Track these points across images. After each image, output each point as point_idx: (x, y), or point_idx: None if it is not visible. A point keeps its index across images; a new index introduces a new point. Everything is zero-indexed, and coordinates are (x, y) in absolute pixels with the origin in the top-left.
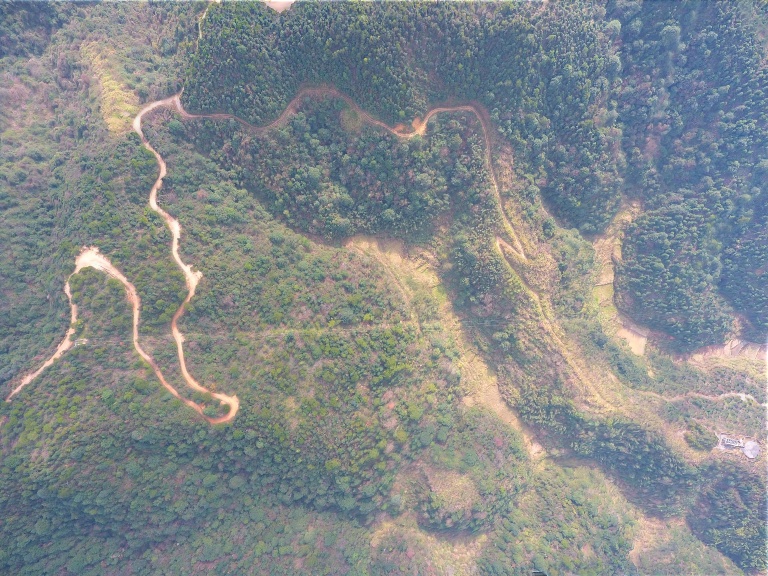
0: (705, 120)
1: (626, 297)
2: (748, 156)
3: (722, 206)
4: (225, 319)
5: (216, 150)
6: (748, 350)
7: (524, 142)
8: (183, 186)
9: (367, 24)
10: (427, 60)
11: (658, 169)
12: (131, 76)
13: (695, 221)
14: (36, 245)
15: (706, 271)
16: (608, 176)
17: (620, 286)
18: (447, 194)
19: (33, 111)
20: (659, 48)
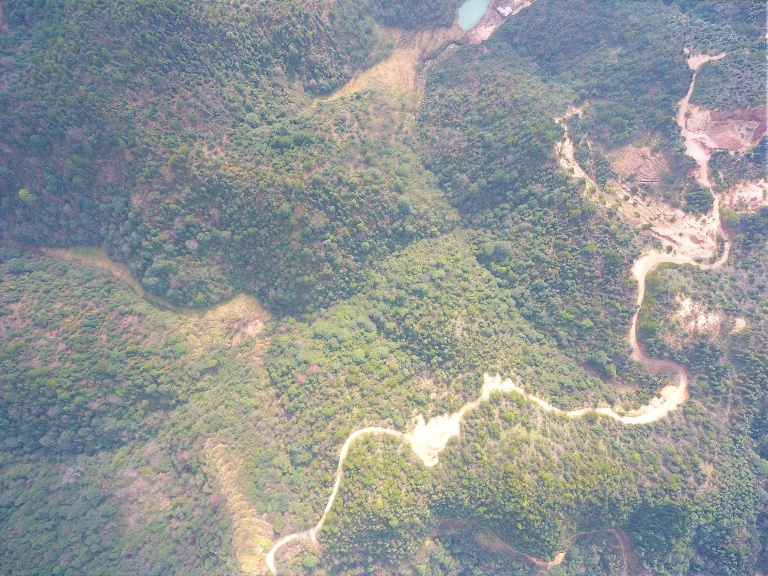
0: None
1: None
2: None
3: None
4: None
5: (346, 571)
6: None
7: None
8: None
9: (528, 506)
10: None
11: None
12: (262, 495)
13: None
14: None
15: None
16: None
17: None
18: None
19: (149, 501)
20: None
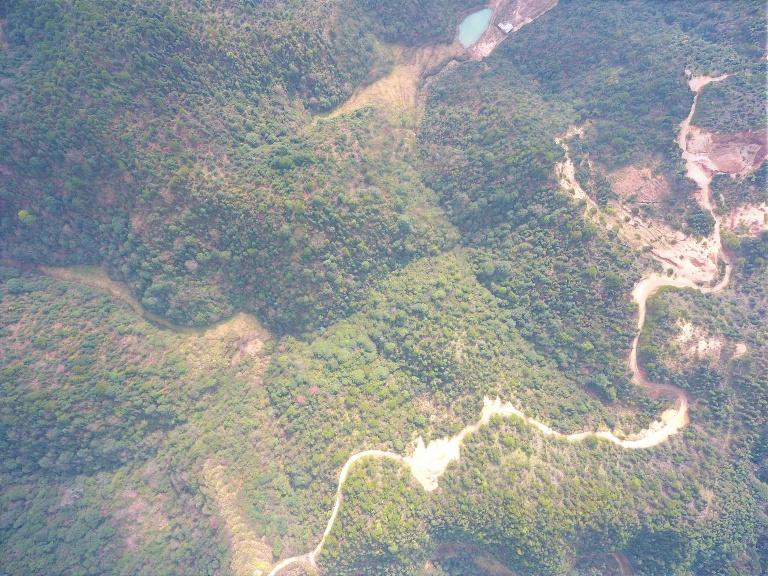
0: None
1: None
2: None
3: None
4: None
5: None
6: None
7: None
8: None
9: (527, 532)
10: None
11: None
12: (261, 517)
13: None
14: None
15: None
16: None
17: None
18: None
19: (148, 522)
20: None
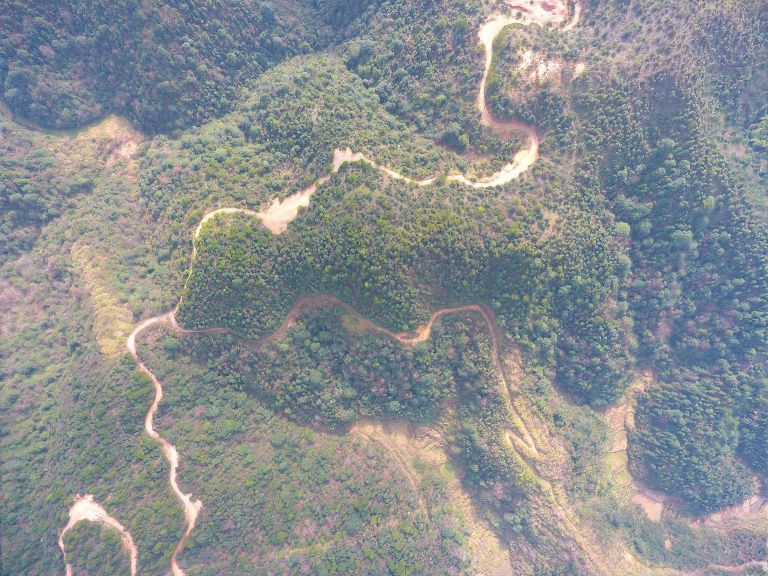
0: (719, 305)
1: (641, 466)
2: (765, 345)
3: (739, 390)
4: (227, 543)
5: (213, 359)
6: (767, 506)
7: (533, 347)
8: (180, 405)
9: (367, 256)
10: (430, 276)
11: (670, 343)
12: (124, 287)
13: (711, 403)
14: (29, 479)
15: (723, 444)
16: (620, 361)
17: (634, 455)
18: (453, 382)
19: (24, 312)
20: (670, 248)
